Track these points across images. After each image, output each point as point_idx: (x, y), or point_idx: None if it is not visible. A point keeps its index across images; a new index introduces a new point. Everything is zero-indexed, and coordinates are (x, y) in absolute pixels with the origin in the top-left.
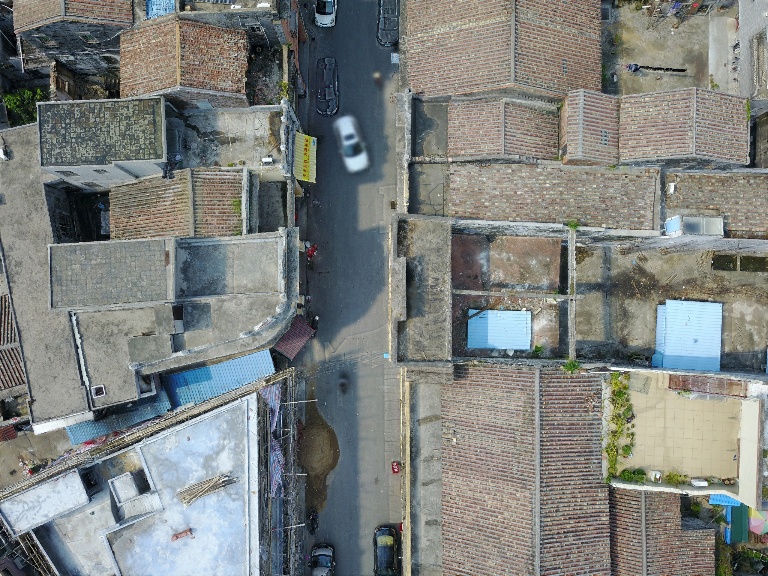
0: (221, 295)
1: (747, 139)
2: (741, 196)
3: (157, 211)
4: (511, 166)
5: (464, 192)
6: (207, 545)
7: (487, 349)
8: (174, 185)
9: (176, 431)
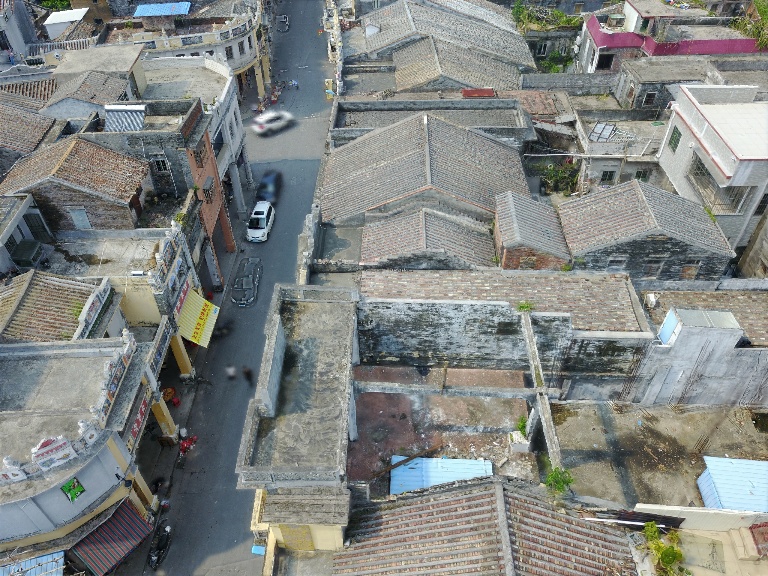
0: None
1: (721, 236)
2: (748, 311)
3: None
4: (438, 271)
5: (379, 294)
6: None
7: None
8: (7, 290)
9: None
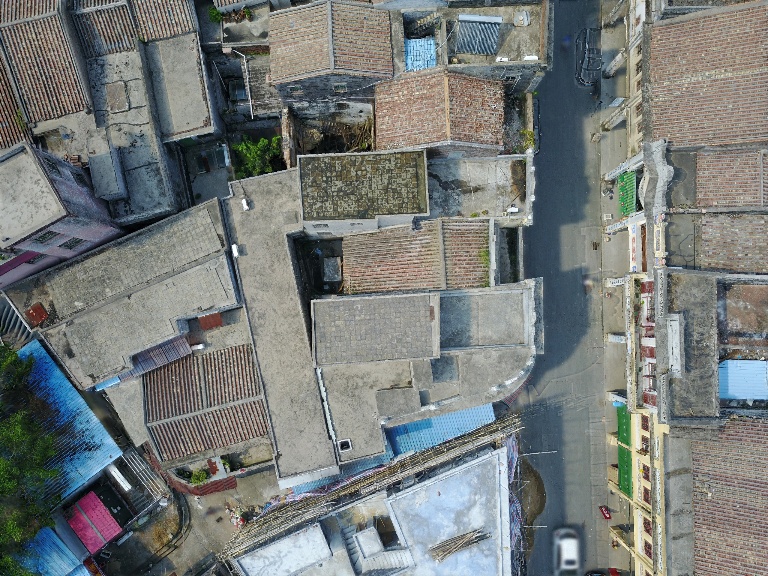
0: (468, 347)
1: None
2: None
3: (401, 262)
4: (764, 217)
5: (717, 243)
6: None
7: (727, 399)
8: (422, 236)
9: (427, 486)
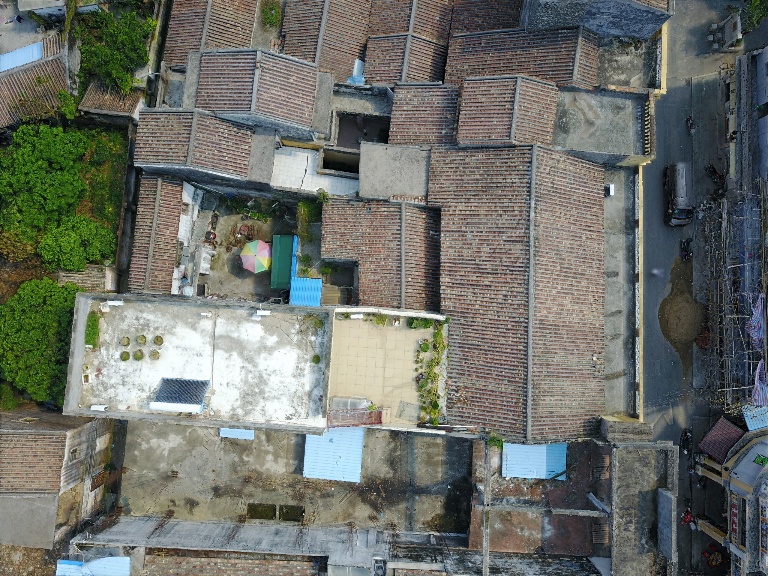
0: None
1: None
2: None
3: None
4: None
5: None
6: None
7: None
8: None
9: None
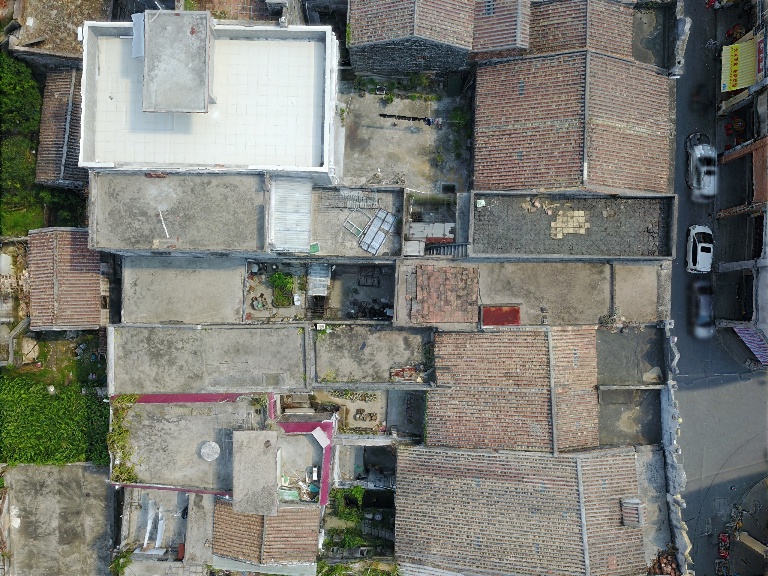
0: None
1: (350, 6)
2: None
3: None
4: None
5: None
6: None
7: None
8: None
9: None
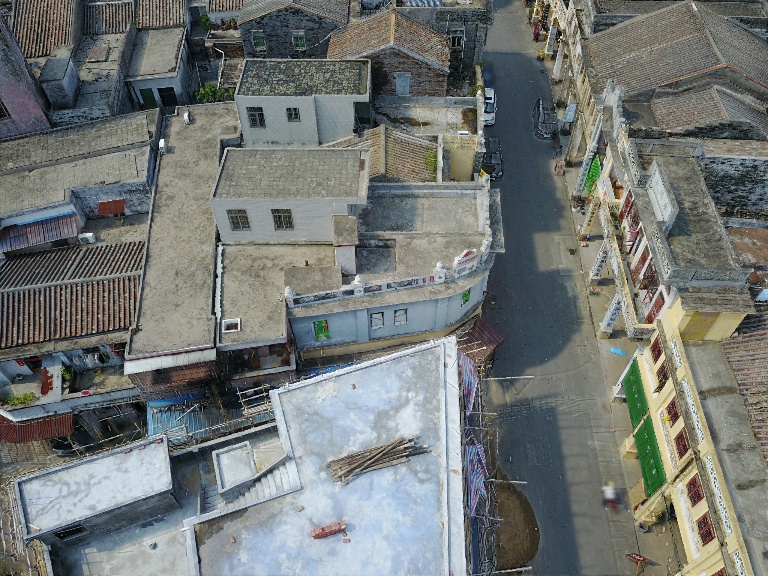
0: None
1: None
2: None
3: None
4: (737, 140)
5: None
6: (371, 557)
7: None
8: (363, 142)
9: (336, 375)
